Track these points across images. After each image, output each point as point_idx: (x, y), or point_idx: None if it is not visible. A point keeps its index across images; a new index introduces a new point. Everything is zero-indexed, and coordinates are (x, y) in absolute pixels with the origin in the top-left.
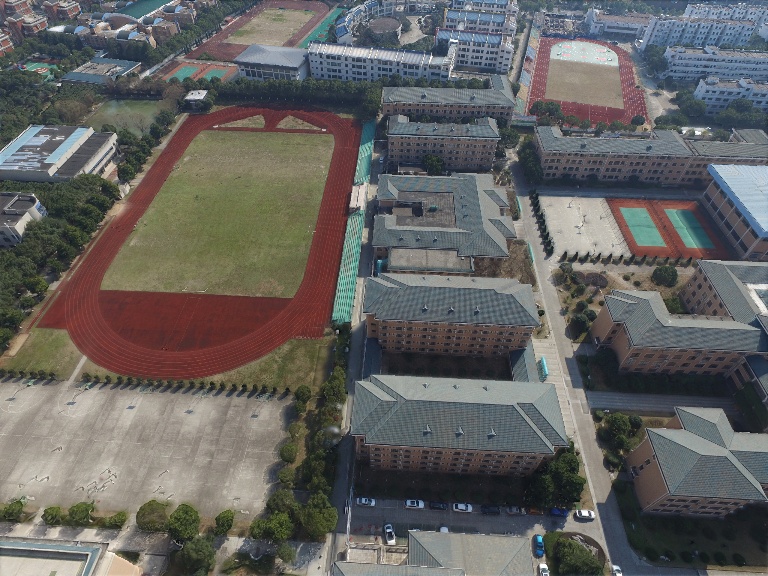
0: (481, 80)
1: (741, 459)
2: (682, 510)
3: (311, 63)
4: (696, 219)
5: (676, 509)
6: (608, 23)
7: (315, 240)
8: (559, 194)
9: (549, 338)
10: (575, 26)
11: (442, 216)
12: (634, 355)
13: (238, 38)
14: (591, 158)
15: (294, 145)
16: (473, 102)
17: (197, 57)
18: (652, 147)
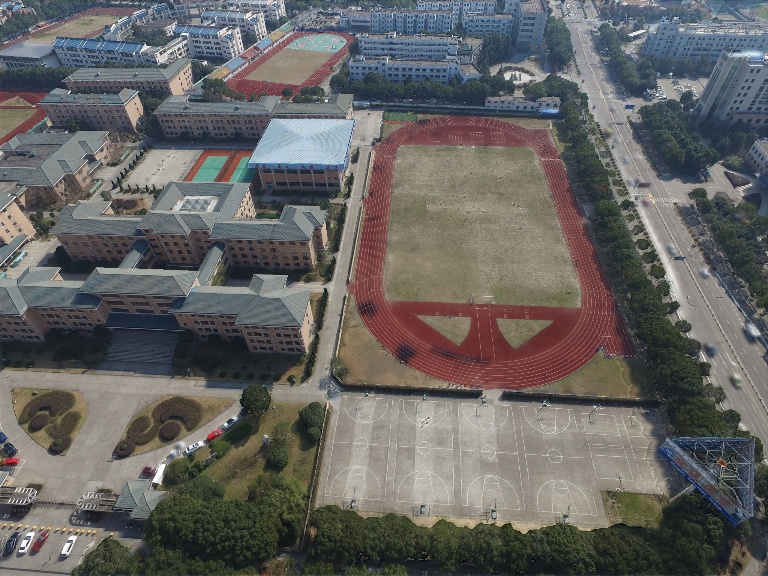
0: None
1: (22, 291)
2: (11, 335)
3: (59, 55)
4: None
5: (6, 334)
6: (351, 17)
7: None
8: (171, 148)
9: (50, 241)
10: (337, 22)
11: (35, 160)
12: (66, 243)
13: (37, 39)
14: (195, 118)
15: None
16: (135, 79)
17: None
18: (239, 108)
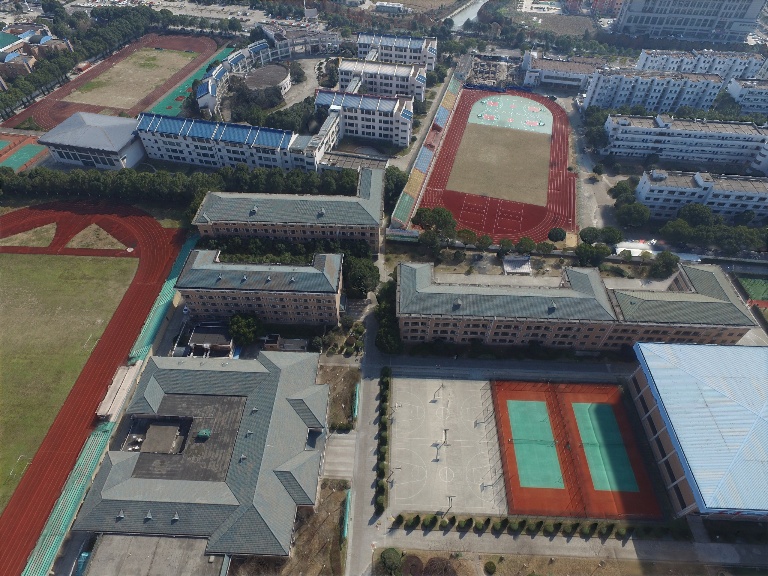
0: (358, 169)
1: None
2: None
3: (144, 141)
4: (617, 424)
5: None
6: (545, 72)
7: (22, 484)
8: (424, 373)
9: None
10: (509, 72)
11: (212, 452)
12: None
13: (84, 94)
14: (469, 321)
15: (76, 280)
16: (321, 221)
17: (16, 125)
18: (556, 308)
